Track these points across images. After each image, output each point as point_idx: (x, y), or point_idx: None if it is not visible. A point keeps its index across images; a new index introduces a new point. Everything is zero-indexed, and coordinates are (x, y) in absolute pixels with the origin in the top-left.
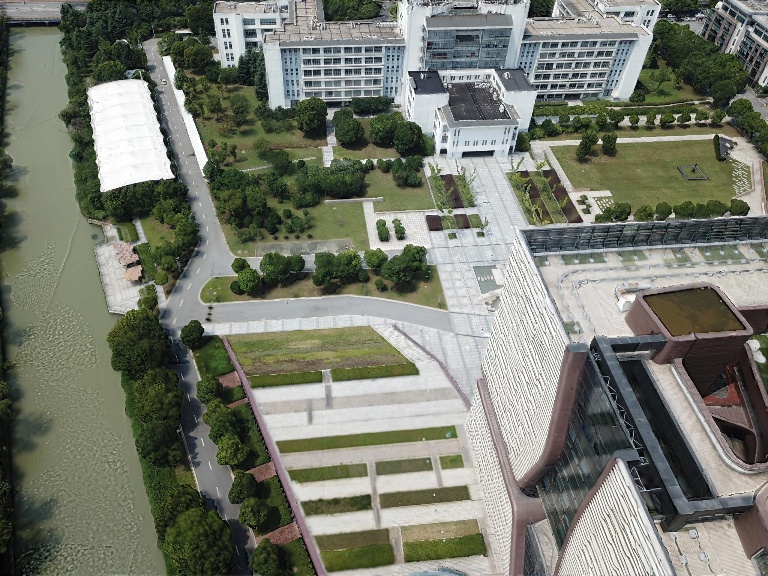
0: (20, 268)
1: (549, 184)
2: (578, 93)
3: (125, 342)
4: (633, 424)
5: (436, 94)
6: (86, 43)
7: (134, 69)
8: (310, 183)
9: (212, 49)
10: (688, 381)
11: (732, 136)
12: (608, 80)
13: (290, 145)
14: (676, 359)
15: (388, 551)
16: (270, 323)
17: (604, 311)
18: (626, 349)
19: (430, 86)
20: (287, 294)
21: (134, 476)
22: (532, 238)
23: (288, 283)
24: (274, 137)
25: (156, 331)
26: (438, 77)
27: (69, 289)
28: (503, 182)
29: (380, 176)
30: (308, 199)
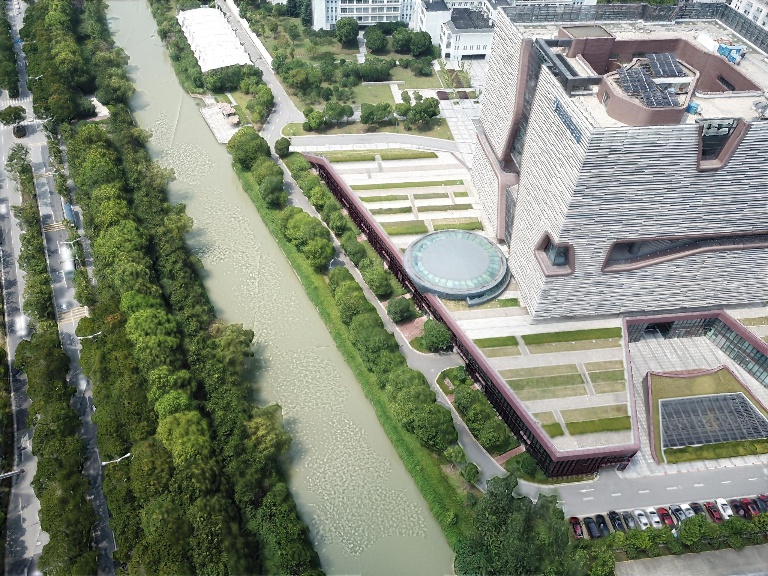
0: (143, 128)
1: None
2: None
3: (244, 140)
4: (552, 62)
5: (442, 11)
6: None
7: (206, 4)
8: (352, 69)
9: None
10: None
11: None
12: None
13: None
14: (578, 54)
15: (424, 227)
16: (332, 146)
17: None
18: (552, 45)
19: (437, 7)
20: (342, 132)
21: (253, 222)
22: (506, 12)
23: (342, 126)
24: None
25: (261, 139)
26: (443, 2)
27: (185, 134)
28: None
29: (401, 70)
30: (351, 81)
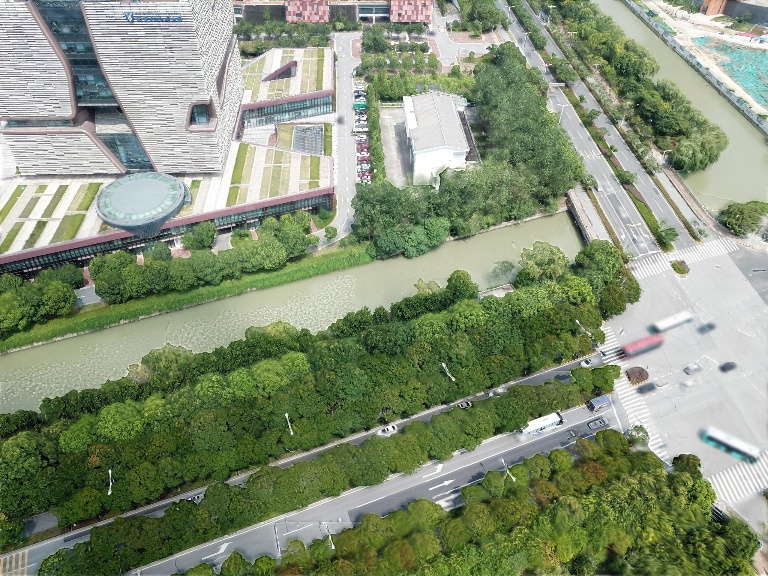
0: None
1: None
2: None
3: None
4: (72, 3)
5: None
6: None
7: None
8: None
9: None
10: None
11: None
12: None
13: None
14: None
15: (77, 215)
16: None
17: None
18: None
19: None
20: None
21: None
22: None
23: None
24: None
25: None
26: None
27: None
28: None
29: None
30: None
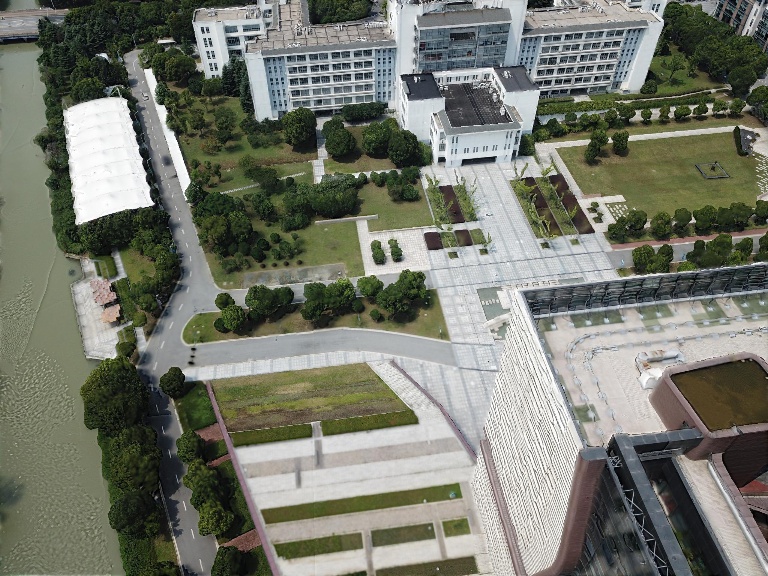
0: None
1: (556, 191)
2: (585, 87)
3: (97, 399)
4: (666, 560)
5: (431, 99)
6: (64, 59)
7: (114, 85)
8: (298, 204)
9: (196, 58)
10: (731, 486)
11: (754, 127)
12: (616, 72)
13: (278, 160)
14: (714, 455)
15: None
16: (258, 364)
17: (623, 389)
18: (653, 448)
19: (424, 90)
20: (276, 330)
21: (112, 546)
22: (534, 299)
23: (277, 317)
24: (261, 152)
25: (132, 383)
26: (433, 80)
27: (45, 332)
28: (507, 191)
29: (374, 190)
30: (297, 221)
